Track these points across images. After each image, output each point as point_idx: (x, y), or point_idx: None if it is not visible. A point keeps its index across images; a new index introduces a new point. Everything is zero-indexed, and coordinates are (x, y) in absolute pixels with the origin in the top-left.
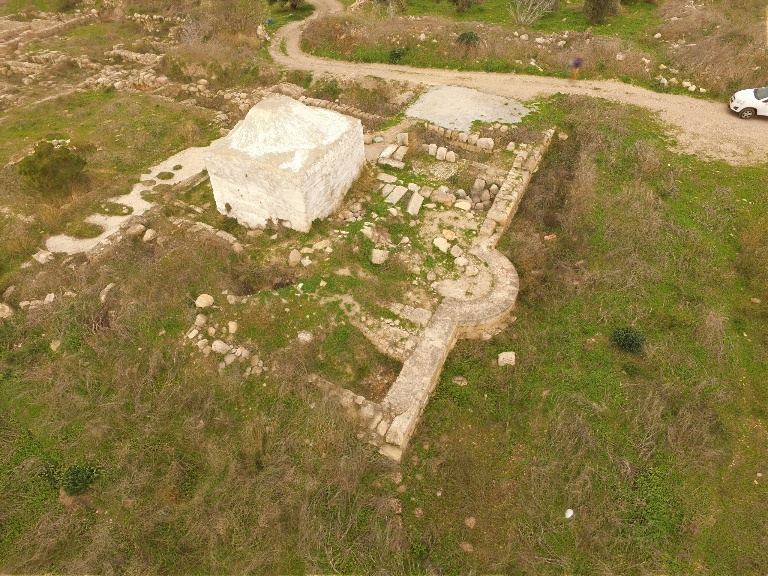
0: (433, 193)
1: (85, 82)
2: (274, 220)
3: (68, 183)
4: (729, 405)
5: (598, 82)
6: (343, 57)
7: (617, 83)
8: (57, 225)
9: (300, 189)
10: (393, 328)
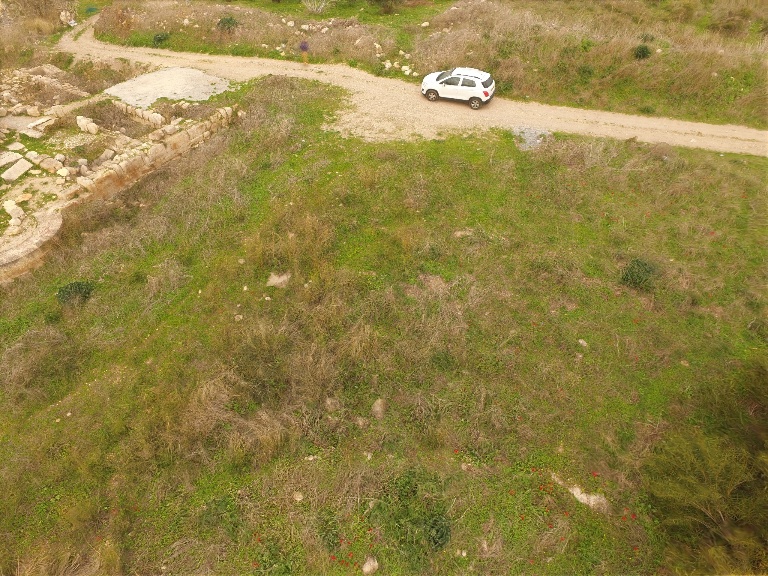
0: (44, 160)
1: None
2: None
3: None
4: (107, 352)
5: (327, 66)
6: (119, 41)
7: (343, 67)
8: None
9: None
10: None
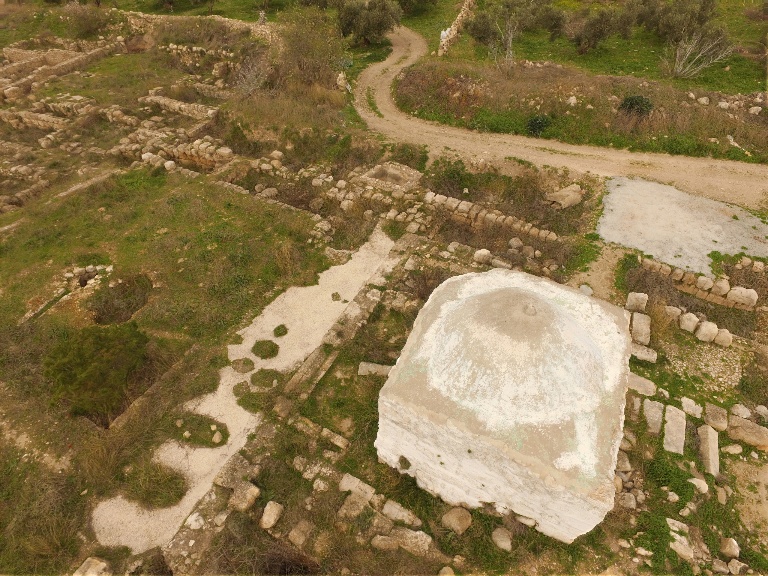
0: (730, 423)
1: (120, 148)
2: (499, 507)
3: (122, 383)
4: None
5: None
6: (460, 123)
7: None
8: (110, 481)
9: (601, 513)
10: None
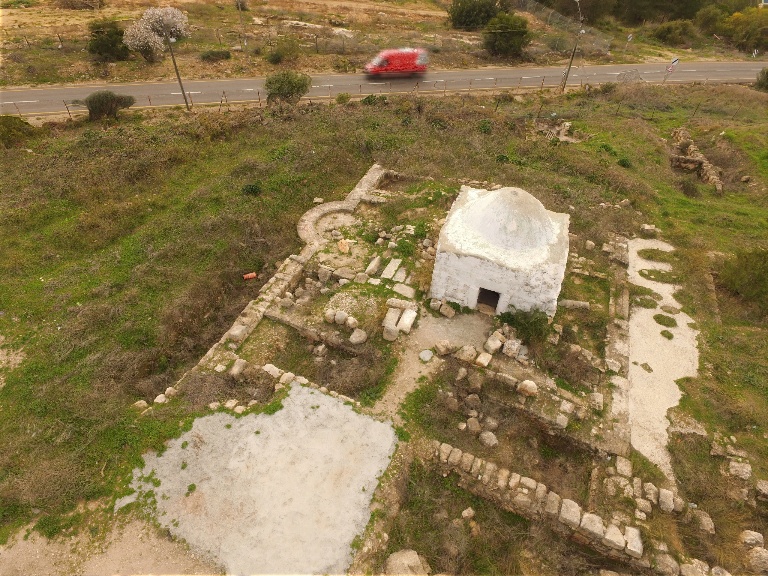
0: (355, 275)
1: None
2: None
3: None
4: None
5: None
6: None
7: None
8: None
9: None
10: (383, 192)
